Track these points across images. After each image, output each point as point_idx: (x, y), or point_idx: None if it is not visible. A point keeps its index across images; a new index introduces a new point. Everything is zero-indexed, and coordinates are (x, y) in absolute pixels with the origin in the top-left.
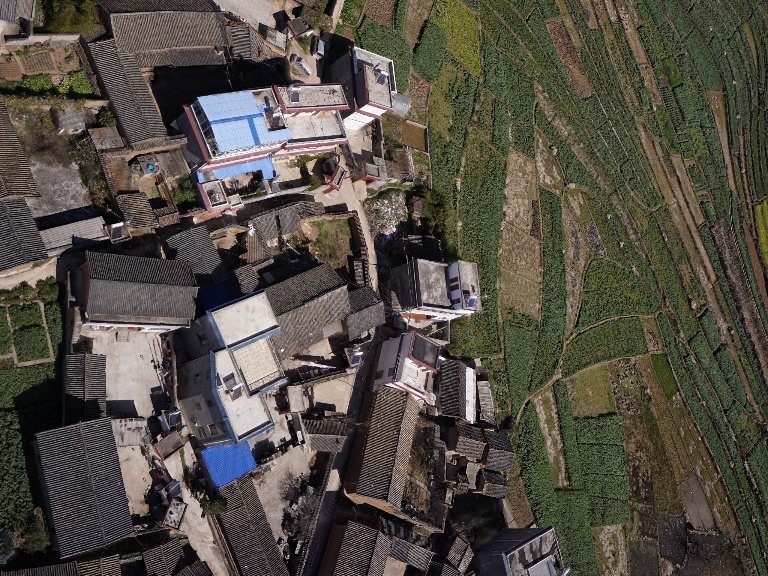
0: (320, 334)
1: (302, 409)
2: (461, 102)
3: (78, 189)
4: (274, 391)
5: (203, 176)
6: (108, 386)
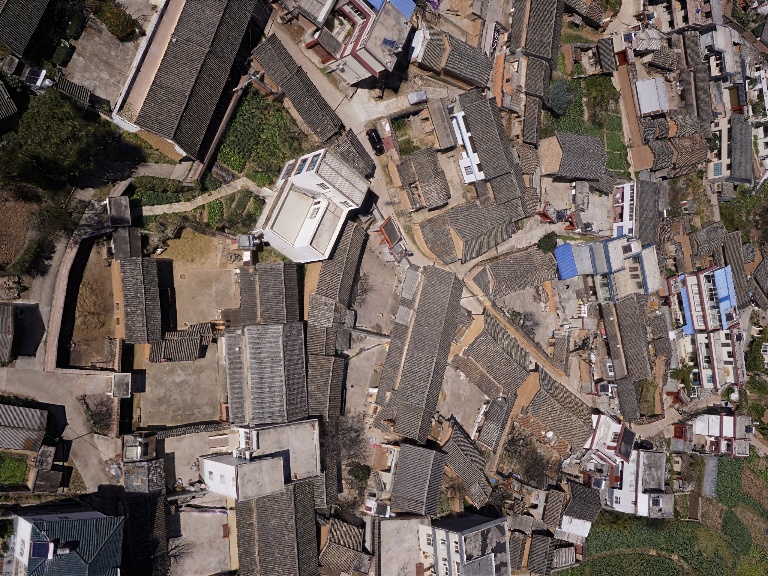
0: (616, 357)
1: (585, 328)
2: (716, 570)
3: (662, 207)
4: (586, 313)
5: (682, 279)
6: (591, 199)
